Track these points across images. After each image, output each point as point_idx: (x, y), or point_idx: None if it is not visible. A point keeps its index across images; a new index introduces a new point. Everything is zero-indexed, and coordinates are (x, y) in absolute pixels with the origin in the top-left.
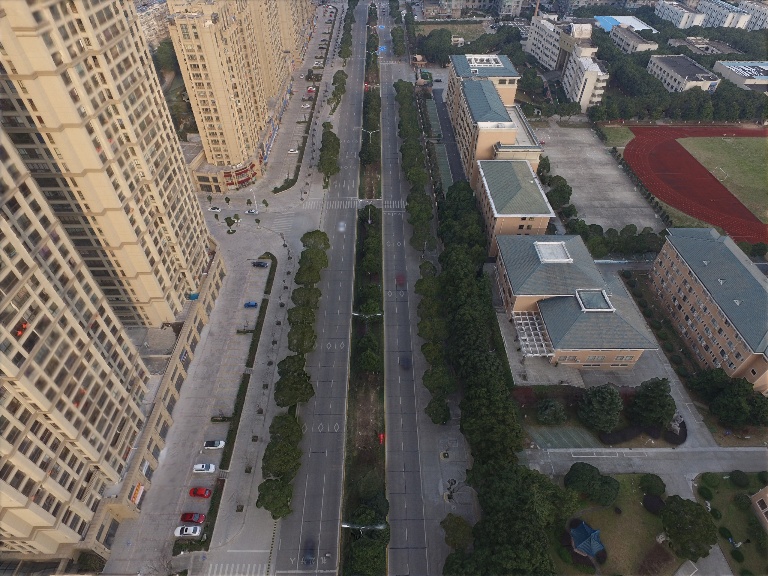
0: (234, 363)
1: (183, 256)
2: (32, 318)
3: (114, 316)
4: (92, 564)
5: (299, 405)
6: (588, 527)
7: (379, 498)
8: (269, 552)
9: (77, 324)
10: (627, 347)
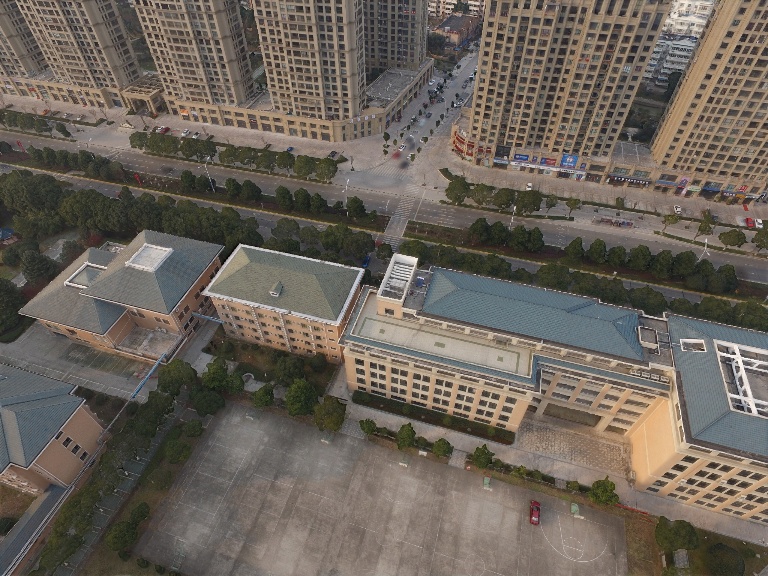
0: (246, 143)
1: (292, 85)
2: (170, 0)
3: (225, 53)
4: (164, 105)
5: (197, 164)
6: (7, 236)
7: (106, 168)
8: (132, 150)
9: (189, 25)
10: (42, 290)
